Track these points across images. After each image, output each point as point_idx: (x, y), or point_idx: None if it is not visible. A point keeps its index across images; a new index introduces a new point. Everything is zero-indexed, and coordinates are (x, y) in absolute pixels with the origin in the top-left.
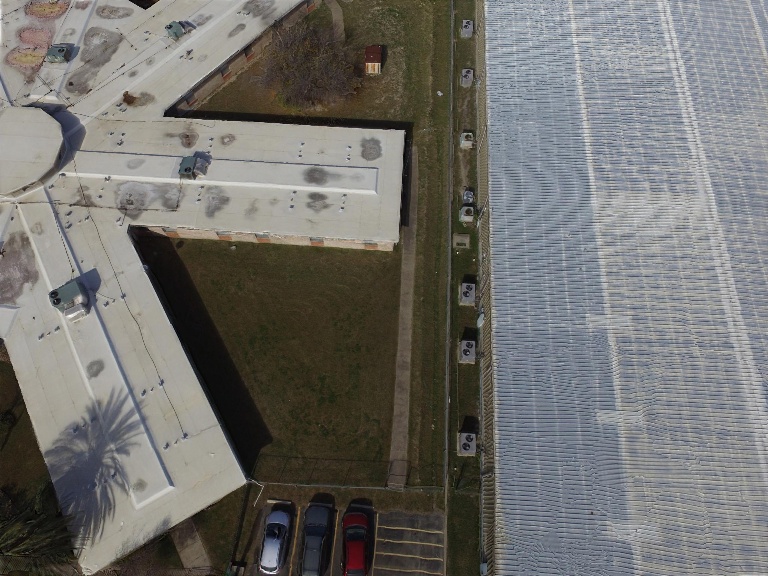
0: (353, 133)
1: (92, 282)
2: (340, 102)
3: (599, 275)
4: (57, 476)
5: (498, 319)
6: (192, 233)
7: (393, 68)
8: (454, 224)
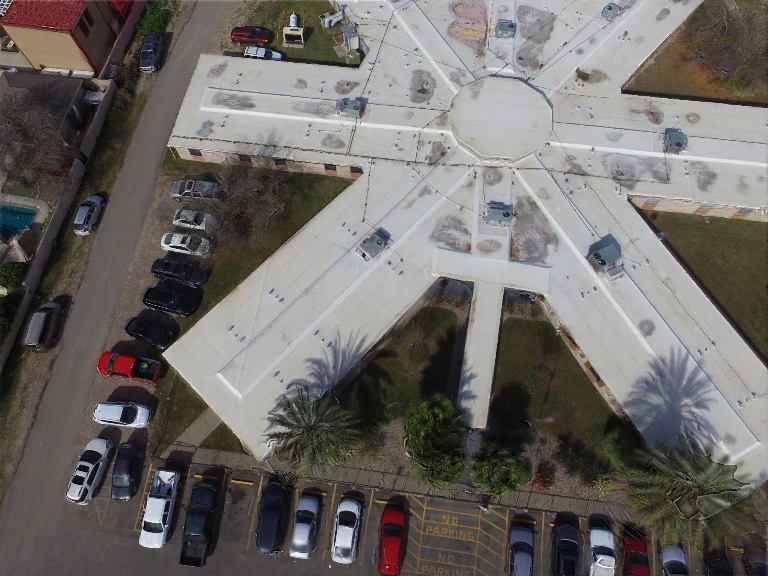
0: None
1: None
2: (763, 88)
3: None
4: (643, 426)
5: None
6: (672, 206)
7: None
8: None
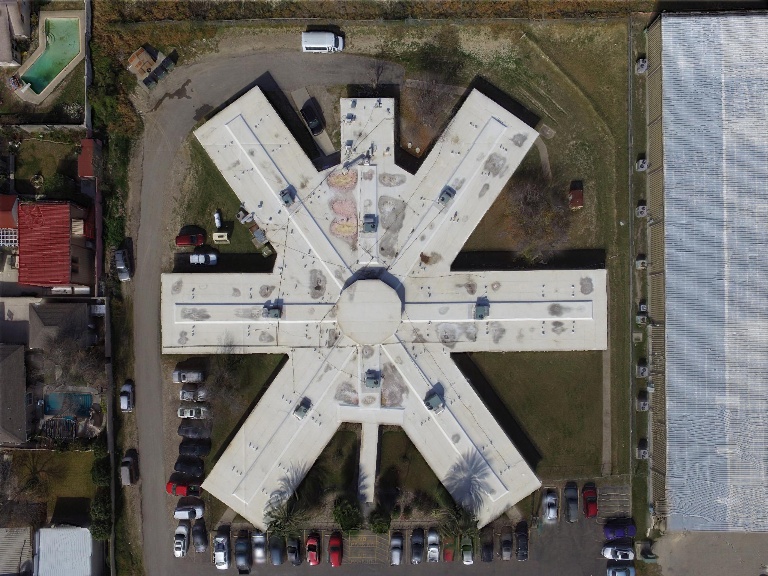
0: (574, 274)
1: (439, 390)
2: None
3: (725, 373)
4: (452, 491)
5: (669, 402)
6: None
7: (588, 202)
8: (633, 326)
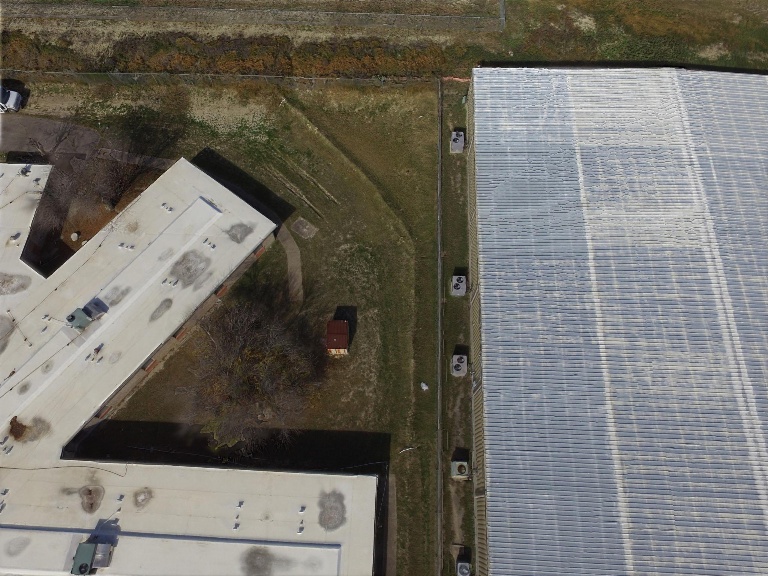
0: (308, 482)
1: None
2: None
3: None
4: None
5: None
6: None
7: (364, 344)
8: None
